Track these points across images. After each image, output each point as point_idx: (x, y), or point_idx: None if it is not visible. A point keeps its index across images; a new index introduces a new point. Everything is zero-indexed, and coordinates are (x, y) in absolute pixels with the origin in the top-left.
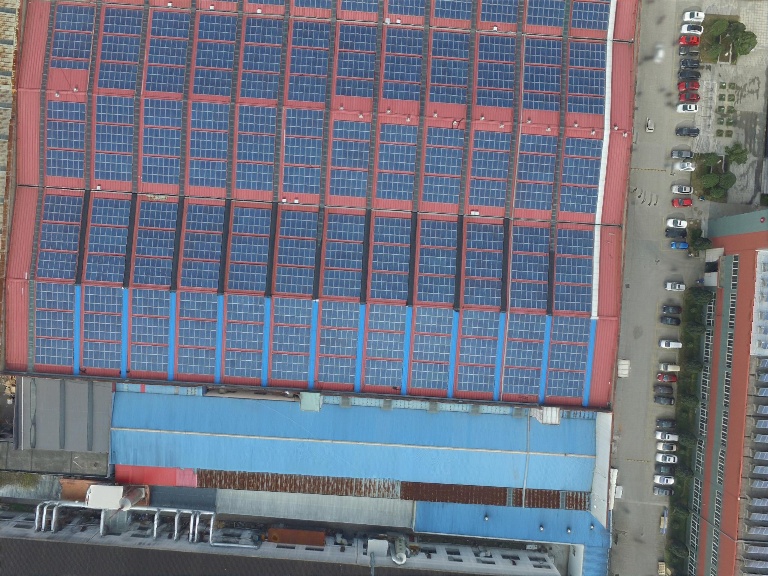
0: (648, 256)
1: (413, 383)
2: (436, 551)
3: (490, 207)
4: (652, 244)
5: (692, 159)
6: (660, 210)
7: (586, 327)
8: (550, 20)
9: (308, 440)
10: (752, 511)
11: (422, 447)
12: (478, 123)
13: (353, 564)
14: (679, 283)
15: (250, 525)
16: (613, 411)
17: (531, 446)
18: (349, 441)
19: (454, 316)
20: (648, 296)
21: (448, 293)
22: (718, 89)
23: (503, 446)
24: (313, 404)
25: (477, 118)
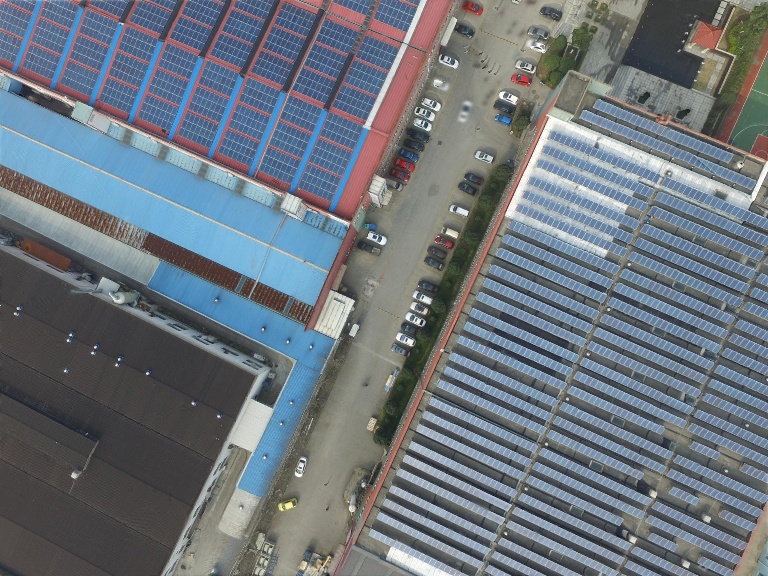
0: (470, 121)
1: (181, 132)
2: (165, 319)
3: None
4: (478, 111)
5: (548, 42)
6: (498, 81)
7: (356, 133)
8: None
9: (80, 161)
10: (449, 366)
11: (177, 205)
12: None
13: (75, 285)
14: (488, 154)
15: (19, 239)
16: (352, 221)
17: (276, 241)
18: (115, 175)
19: (238, 80)
20: (456, 159)
21: (241, 58)
22: None
23: (250, 231)
24: (84, 115)
25: None
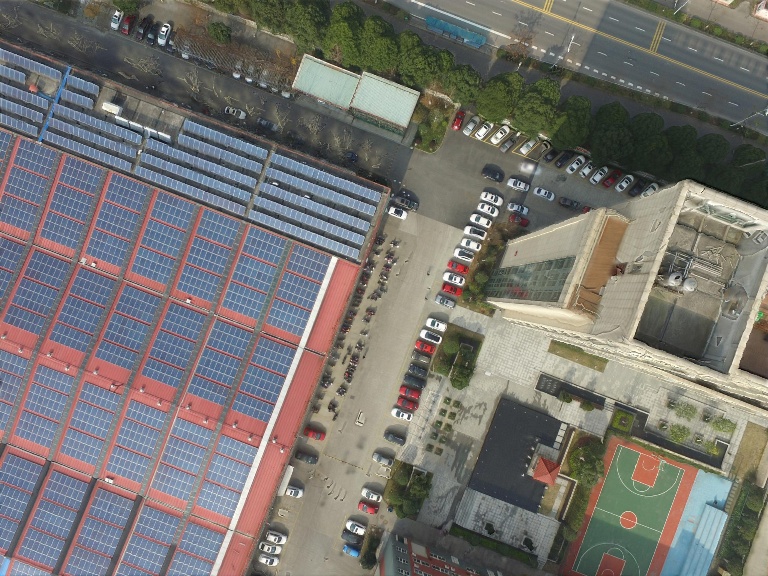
0: (318, 550)
1: None
2: None
3: (127, 479)
4: (326, 539)
5: (394, 465)
6: (345, 507)
7: None
8: (246, 309)
9: None
10: None
11: None
12: (137, 393)
13: None
14: None
15: None
16: None
17: None
18: None
19: None
20: None
21: (52, 556)
22: (442, 403)
23: None
24: None
25: (137, 388)
